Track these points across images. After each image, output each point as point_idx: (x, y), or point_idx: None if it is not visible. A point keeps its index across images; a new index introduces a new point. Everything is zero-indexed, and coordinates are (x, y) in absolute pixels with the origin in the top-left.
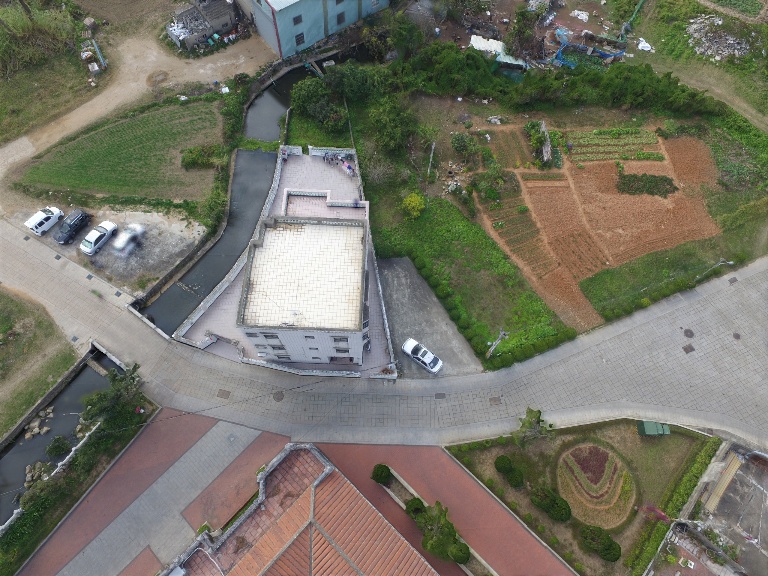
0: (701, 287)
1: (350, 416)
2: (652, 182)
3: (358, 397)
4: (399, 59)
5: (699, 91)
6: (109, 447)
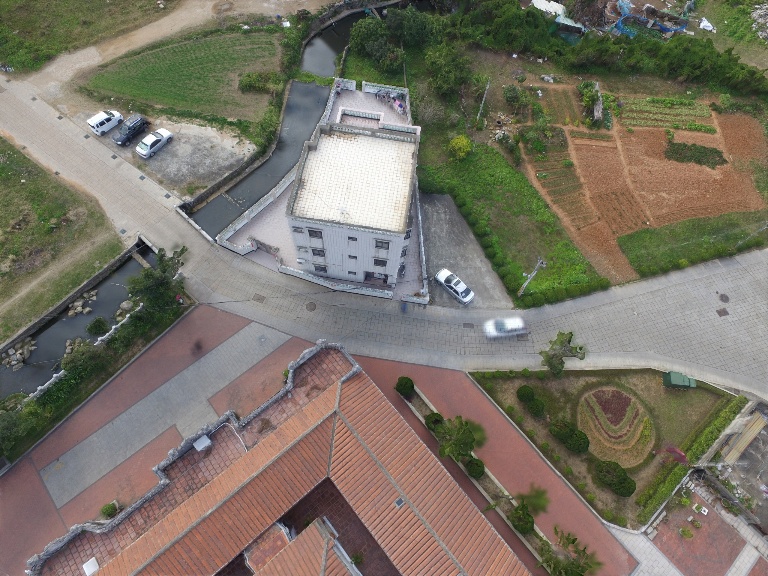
0: (741, 257)
1: (378, 333)
2: (701, 152)
3: (388, 317)
4: (459, 11)
5: (759, 70)
6: (146, 331)
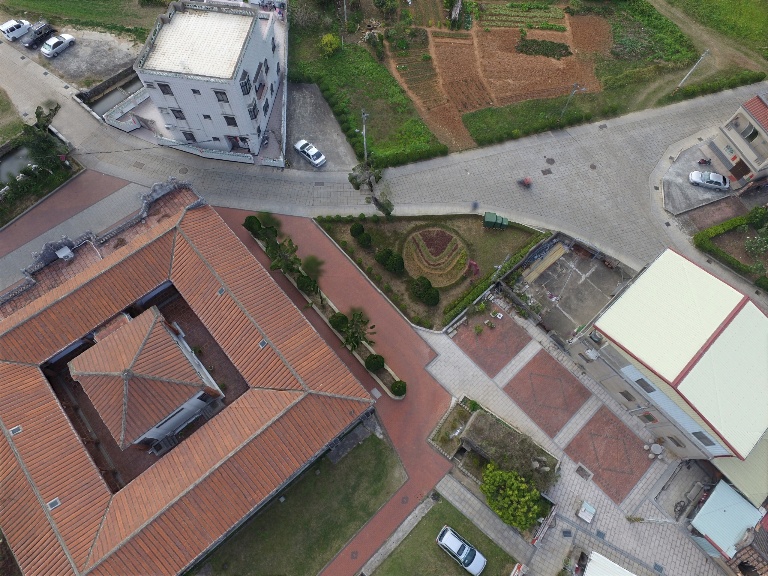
0: (572, 129)
1: (239, 190)
2: (549, 46)
3: (249, 178)
4: None
5: None
6: (39, 190)
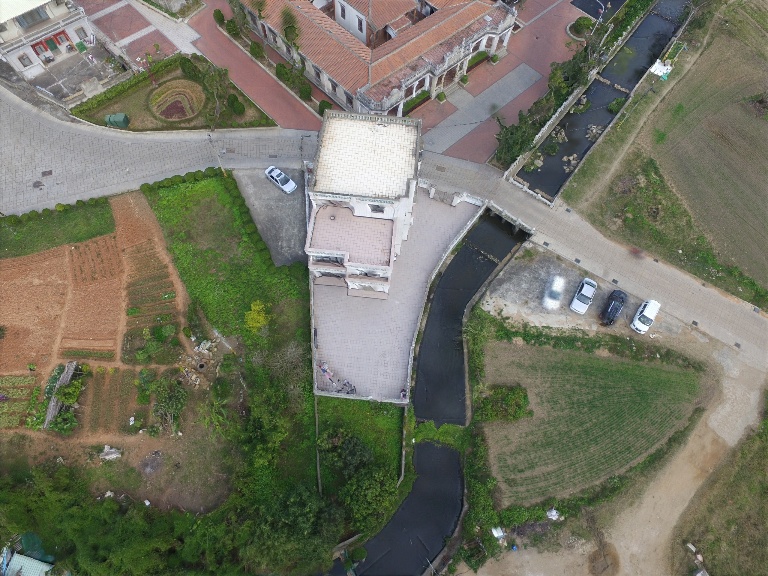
0: None
1: None
2: None
3: None
4: None
5: None
6: None
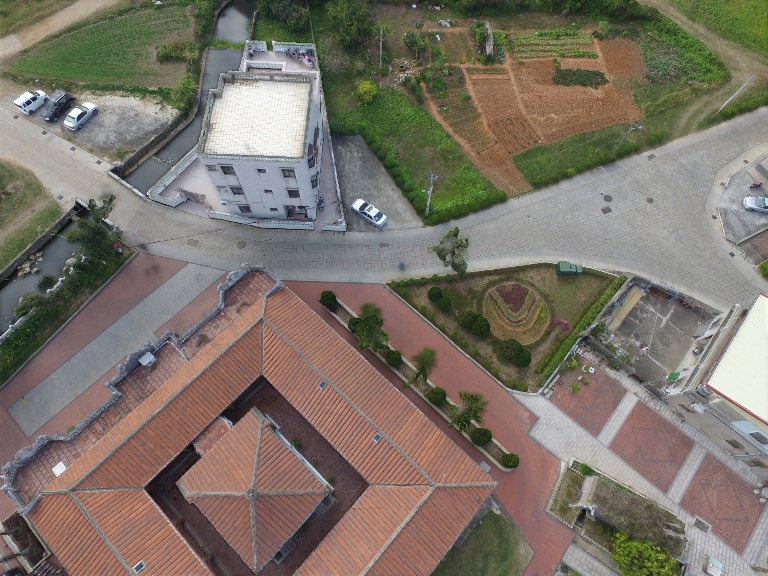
0: (622, 162)
1: (304, 260)
2: (585, 75)
3: (311, 245)
4: None
5: None
6: (92, 282)
